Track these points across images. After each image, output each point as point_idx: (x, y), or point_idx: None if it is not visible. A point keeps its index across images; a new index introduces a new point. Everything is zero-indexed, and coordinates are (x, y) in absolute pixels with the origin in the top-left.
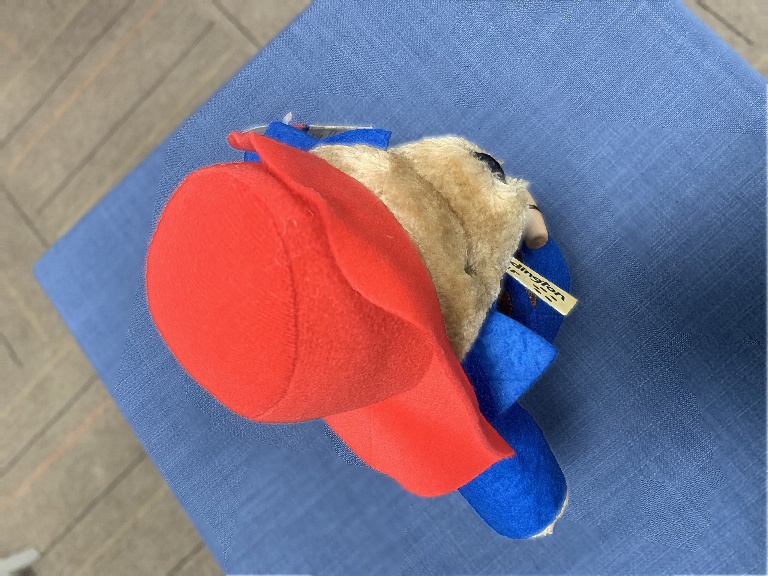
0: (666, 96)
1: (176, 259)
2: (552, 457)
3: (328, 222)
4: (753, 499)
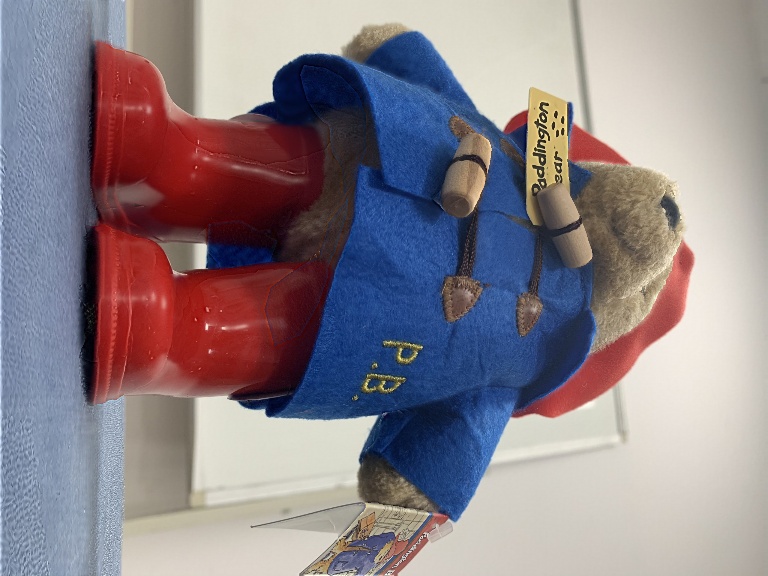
0: None
1: None
2: (431, 54)
3: None
4: None
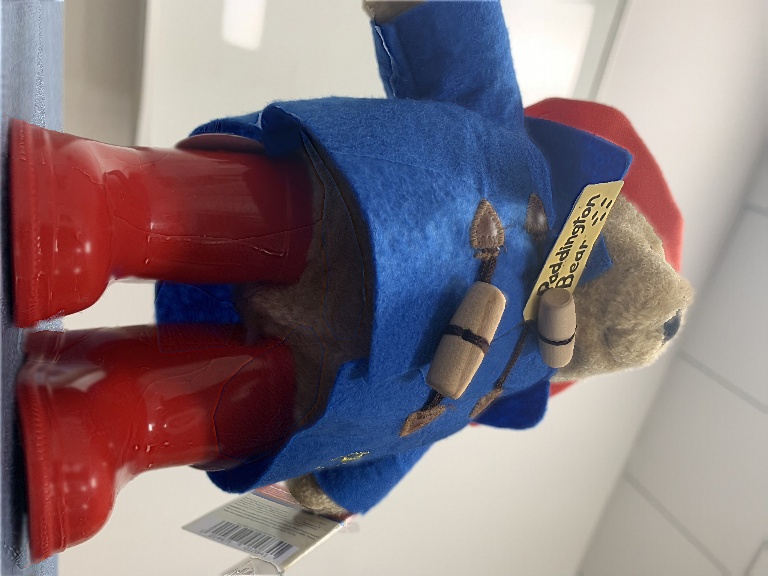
0: None
1: None
2: (490, 25)
3: None
4: None
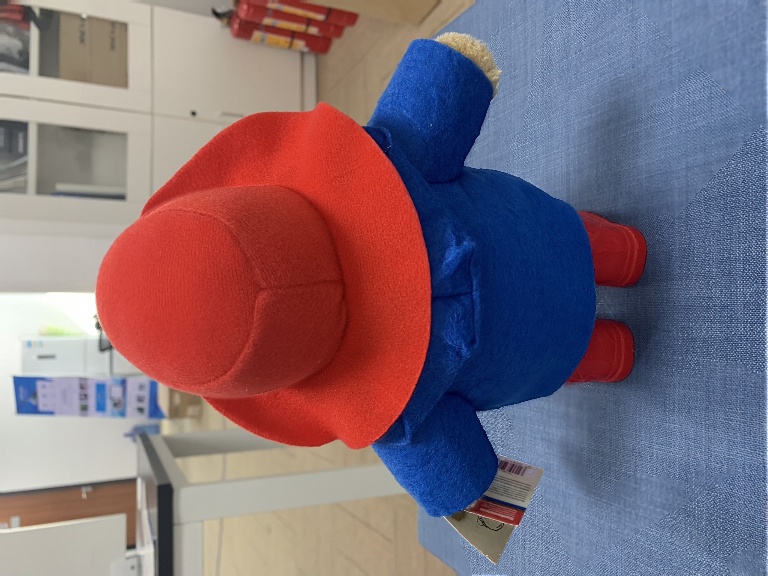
0: None
1: (112, 316)
2: None
3: None
4: (542, 1)
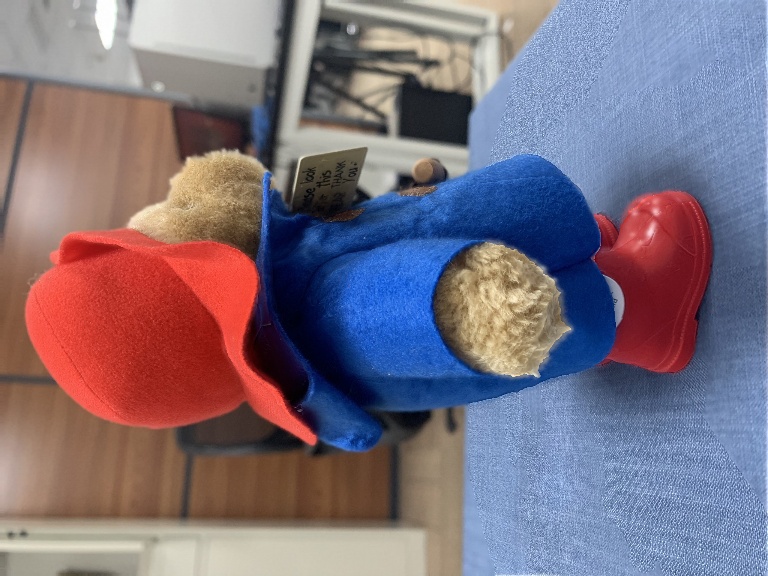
0: (609, 7)
1: None
2: None
3: (49, 255)
4: None
